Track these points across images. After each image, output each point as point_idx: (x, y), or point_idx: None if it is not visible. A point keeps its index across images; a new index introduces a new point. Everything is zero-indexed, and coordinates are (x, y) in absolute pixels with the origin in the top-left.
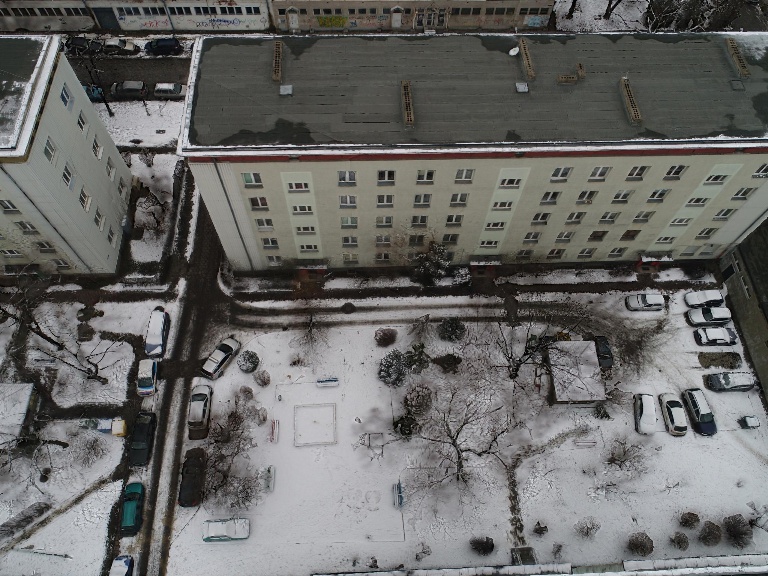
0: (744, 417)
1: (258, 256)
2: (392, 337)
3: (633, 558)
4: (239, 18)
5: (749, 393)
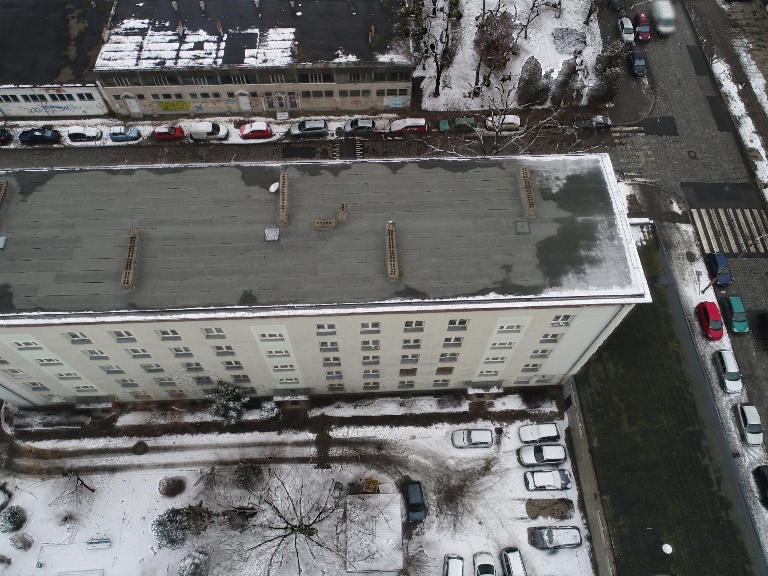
0: None
1: (32, 395)
2: (178, 487)
3: None
4: (73, 104)
5: (578, 550)
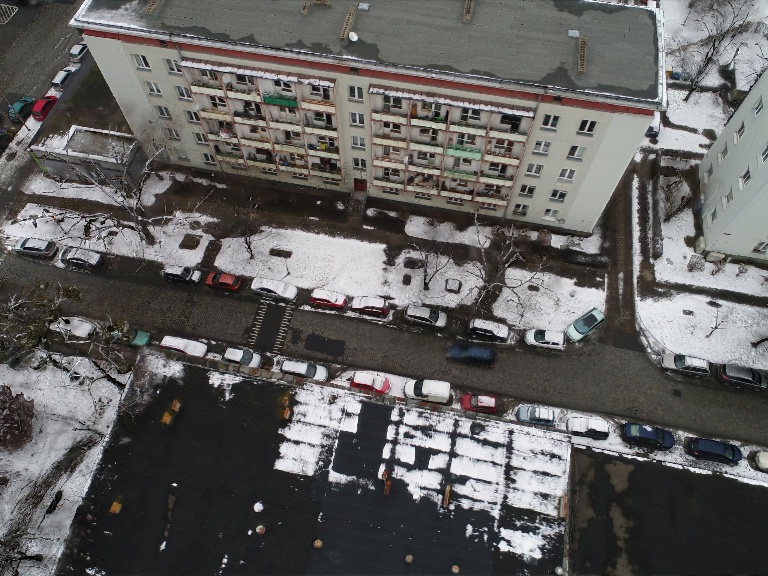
0: None
1: None
2: None
3: None
4: None
5: None
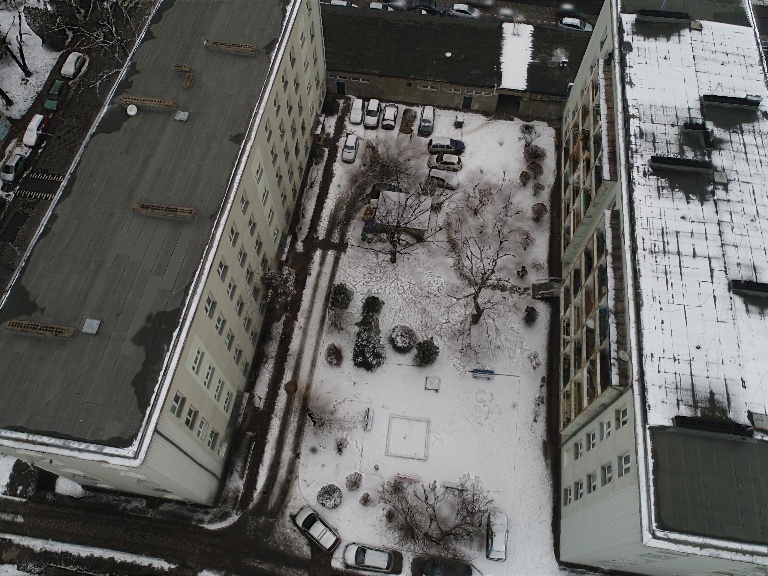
0: (456, 122)
1: (214, 463)
2: (336, 349)
3: (544, 222)
4: None
5: (437, 114)
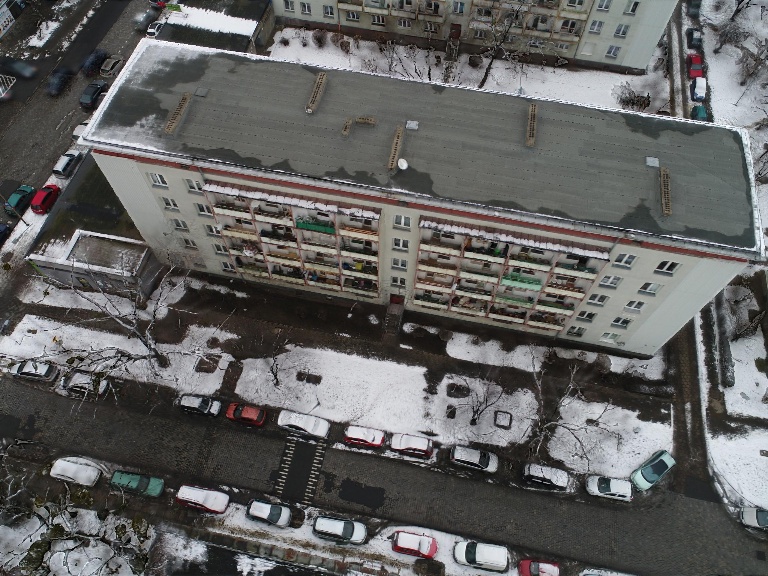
0: None
1: None
2: None
3: None
4: None
5: None
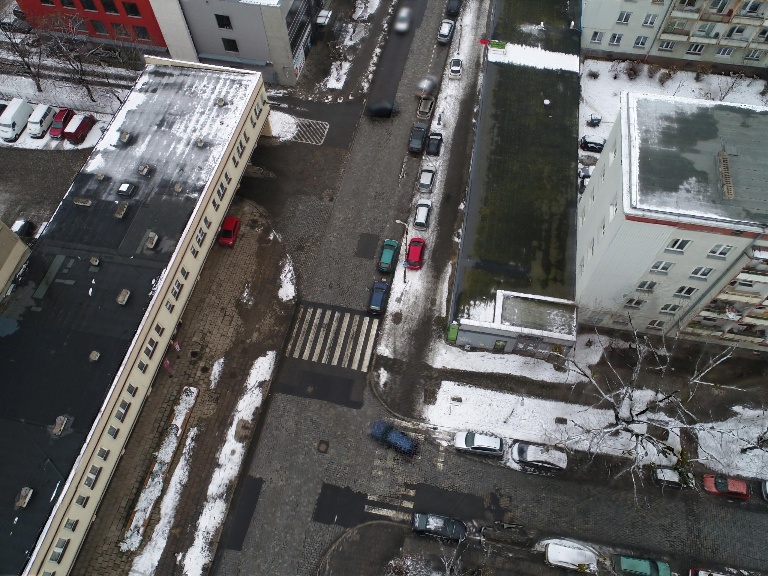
0: None
1: None
2: None
3: None
4: None
5: None
